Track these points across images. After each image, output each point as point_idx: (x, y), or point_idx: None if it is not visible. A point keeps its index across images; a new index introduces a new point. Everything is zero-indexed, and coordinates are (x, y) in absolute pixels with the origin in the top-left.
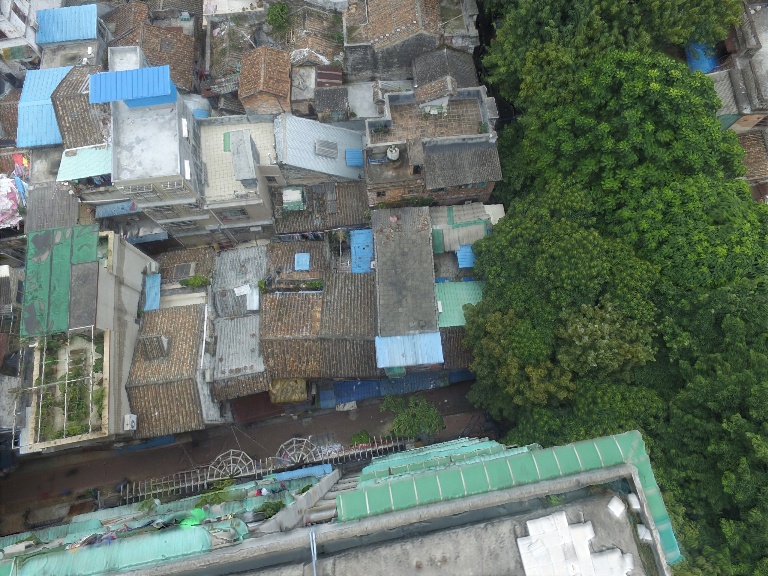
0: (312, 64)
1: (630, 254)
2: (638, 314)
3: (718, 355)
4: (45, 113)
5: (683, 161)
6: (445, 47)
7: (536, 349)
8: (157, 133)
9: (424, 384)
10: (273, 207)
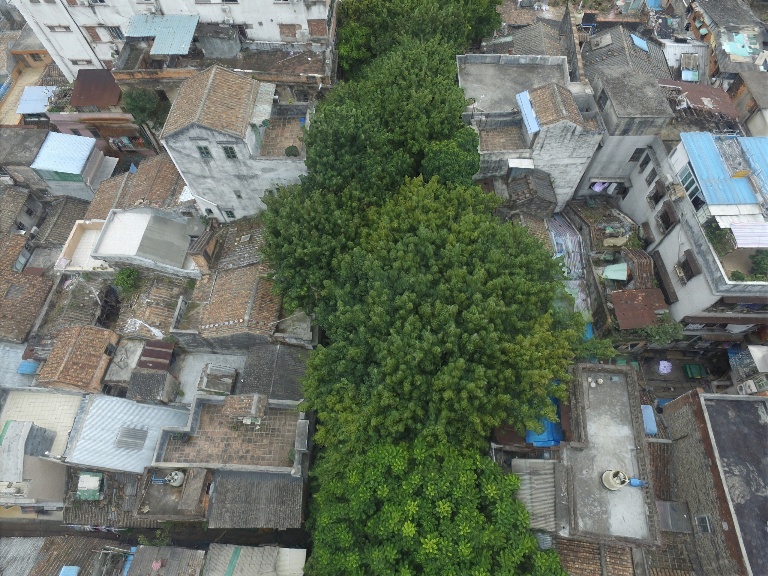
0: (142, 339)
1: None
2: None
3: None
4: None
5: None
6: (279, 343)
7: None
8: None
9: None
10: (67, 491)
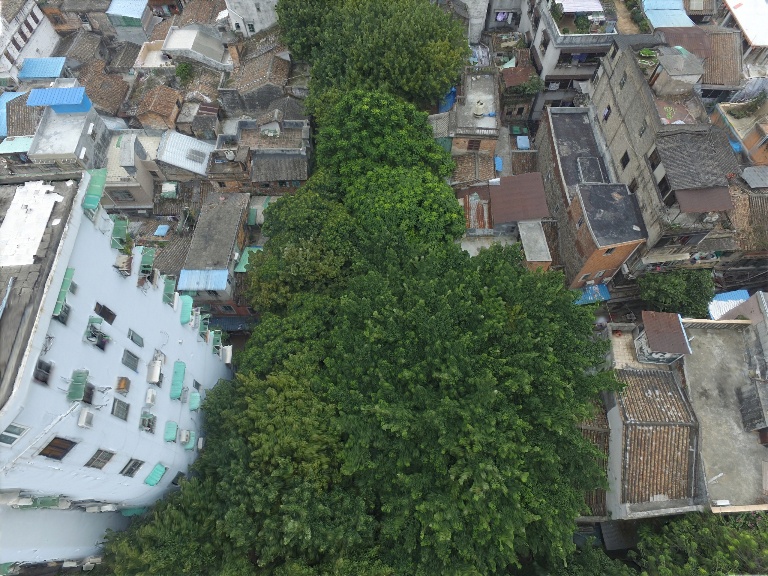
0: (198, 101)
1: (342, 211)
2: (334, 246)
3: (376, 272)
4: (5, 117)
5: (387, 156)
6: (288, 95)
7: (271, 271)
8: (70, 130)
9: (233, 326)
10: (154, 195)
